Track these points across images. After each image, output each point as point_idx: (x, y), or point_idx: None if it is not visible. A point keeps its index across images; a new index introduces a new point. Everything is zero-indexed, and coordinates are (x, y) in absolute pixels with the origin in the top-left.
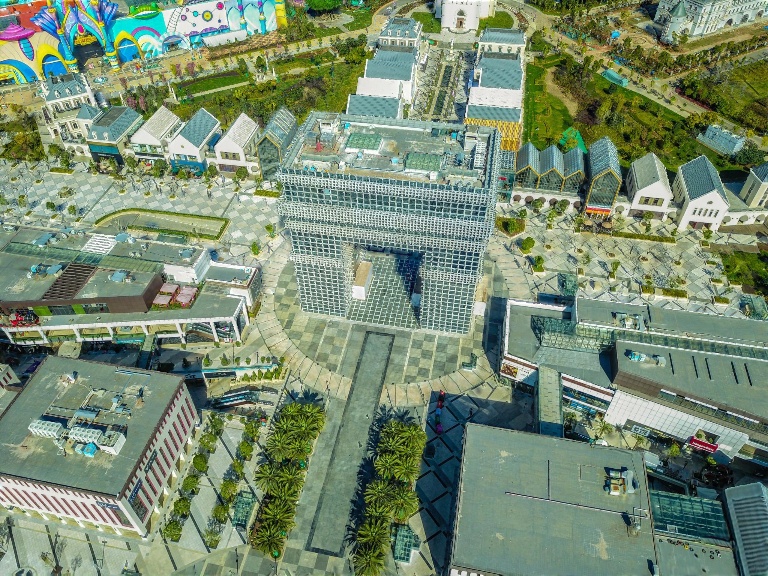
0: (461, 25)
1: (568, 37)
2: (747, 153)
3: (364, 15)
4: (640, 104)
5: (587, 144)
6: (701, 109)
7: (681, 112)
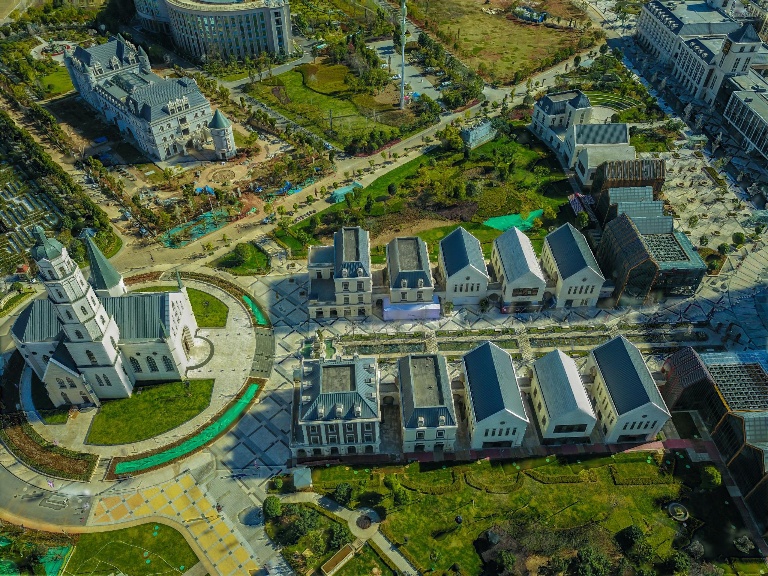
0: (187, 347)
1: (214, 231)
2: (498, 123)
3: (87, 556)
4: (404, 178)
5: (521, 210)
6: (399, 145)
7: (411, 156)
